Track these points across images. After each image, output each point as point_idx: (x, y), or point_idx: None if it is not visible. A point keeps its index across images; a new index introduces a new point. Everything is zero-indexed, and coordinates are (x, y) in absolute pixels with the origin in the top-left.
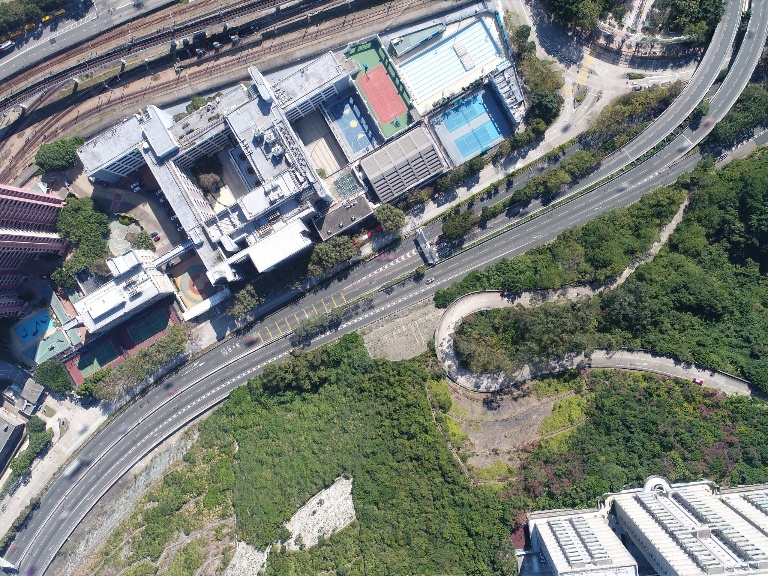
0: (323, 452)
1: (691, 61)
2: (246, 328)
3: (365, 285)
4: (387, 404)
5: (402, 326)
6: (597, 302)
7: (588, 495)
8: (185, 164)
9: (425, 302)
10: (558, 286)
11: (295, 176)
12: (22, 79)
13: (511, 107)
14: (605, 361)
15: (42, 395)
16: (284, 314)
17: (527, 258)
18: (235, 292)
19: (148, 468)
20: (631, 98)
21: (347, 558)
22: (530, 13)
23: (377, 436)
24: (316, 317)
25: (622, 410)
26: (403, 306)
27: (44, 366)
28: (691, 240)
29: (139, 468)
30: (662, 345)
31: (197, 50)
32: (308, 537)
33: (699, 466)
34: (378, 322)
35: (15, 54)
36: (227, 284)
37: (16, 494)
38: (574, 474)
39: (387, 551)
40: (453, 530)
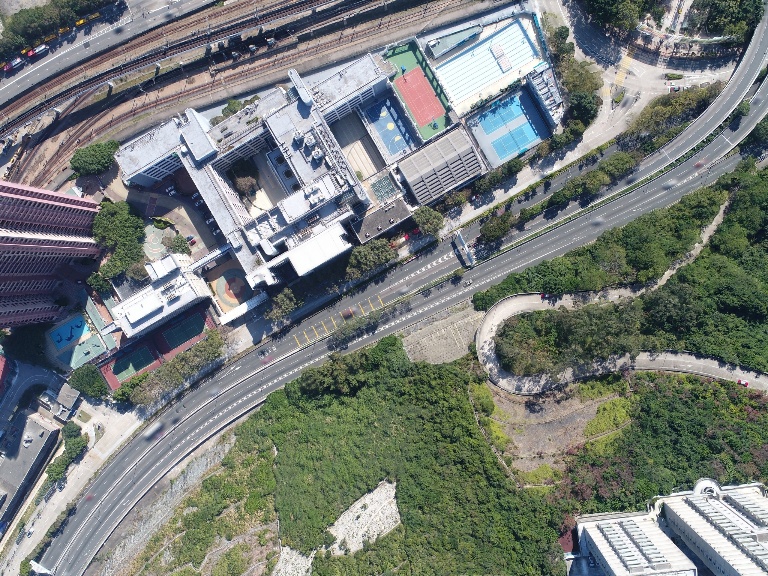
0: (365, 456)
1: (730, 61)
2: (283, 332)
3: (402, 288)
4: (429, 407)
5: (441, 329)
6: (640, 304)
7: (637, 498)
8: (222, 167)
9: (463, 305)
10: (600, 288)
11: (335, 179)
12: (56, 83)
13: (550, 109)
14: (648, 363)
15: (77, 400)
16: (321, 317)
17: (567, 260)
18: (273, 296)
19: (184, 473)
20: (671, 99)
21: (393, 563)
22: (567, 14)
23: (419, 440)
24: (354, 320)
25: (668, 412)
26: (441, 309)
27: (80, 371)
28: (733, 241)
29: (175, 473)
30: (707, 347)
31: (233, 53)
32: (353, 542)
33: (749, 468)
34: (416, 325)
35: (49, 58)
36: (264, 288)
37: (51, 500)
38: (623, 477)
39: (434, 555)
40: (500, 534)
